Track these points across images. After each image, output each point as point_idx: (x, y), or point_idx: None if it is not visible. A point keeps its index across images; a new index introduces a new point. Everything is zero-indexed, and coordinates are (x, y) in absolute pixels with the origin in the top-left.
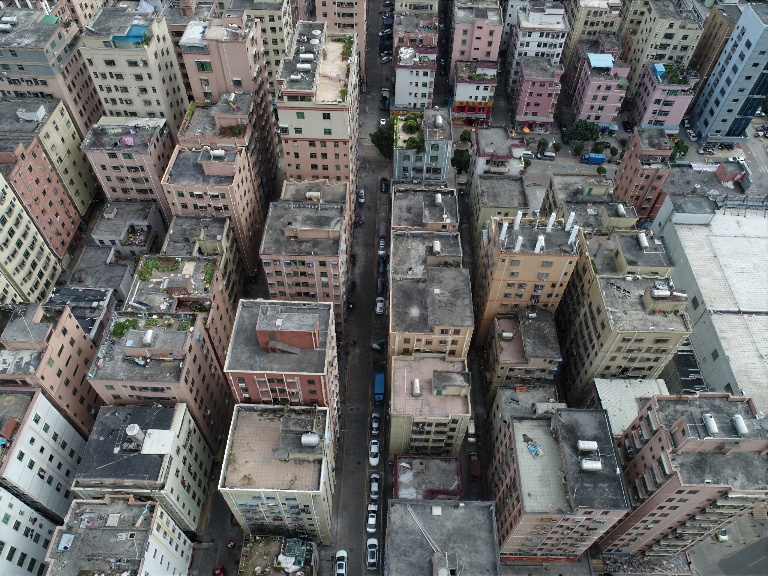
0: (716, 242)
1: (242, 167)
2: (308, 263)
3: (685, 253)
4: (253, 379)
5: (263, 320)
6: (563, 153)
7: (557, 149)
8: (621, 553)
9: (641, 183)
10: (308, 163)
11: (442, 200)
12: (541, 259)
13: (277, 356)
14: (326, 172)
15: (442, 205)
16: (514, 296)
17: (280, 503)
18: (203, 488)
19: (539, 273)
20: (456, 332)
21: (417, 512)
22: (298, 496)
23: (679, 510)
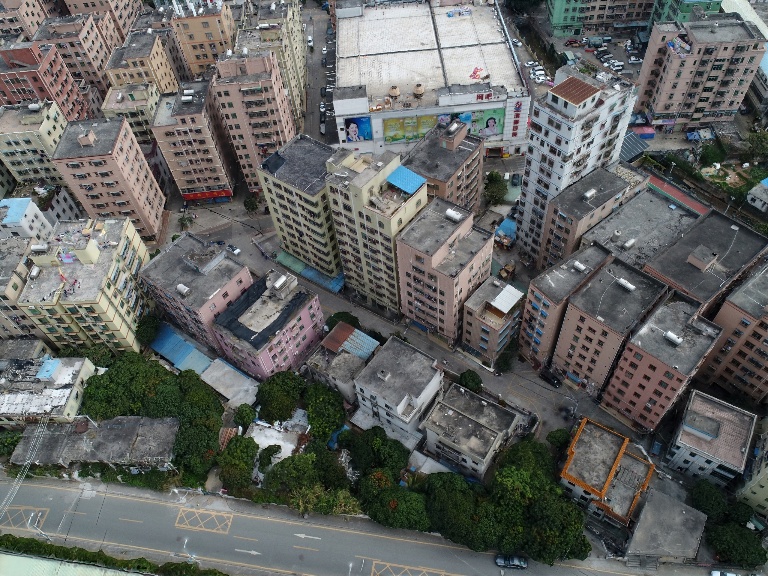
0: (363, 24)
1: (31, 4)
2: (62, 45)
3: (336, 31)
4: (2, 81)
5: (3, 47)
6: (311, 6)
7: (303, 2)
8: (259, 187)
9: (332, 3)
10: (81, 2)
11: (165, 12)
12: (200, 21)
13: (16, 69)
14: (95, 8)
15: (164, 14)
16: (202, 57)
17: (26, 149)
18: (7, 180)
19: (206, 34)
20: (142, 64)
21: (84, 126)
22: (30, 138)
23: (240, 118)
